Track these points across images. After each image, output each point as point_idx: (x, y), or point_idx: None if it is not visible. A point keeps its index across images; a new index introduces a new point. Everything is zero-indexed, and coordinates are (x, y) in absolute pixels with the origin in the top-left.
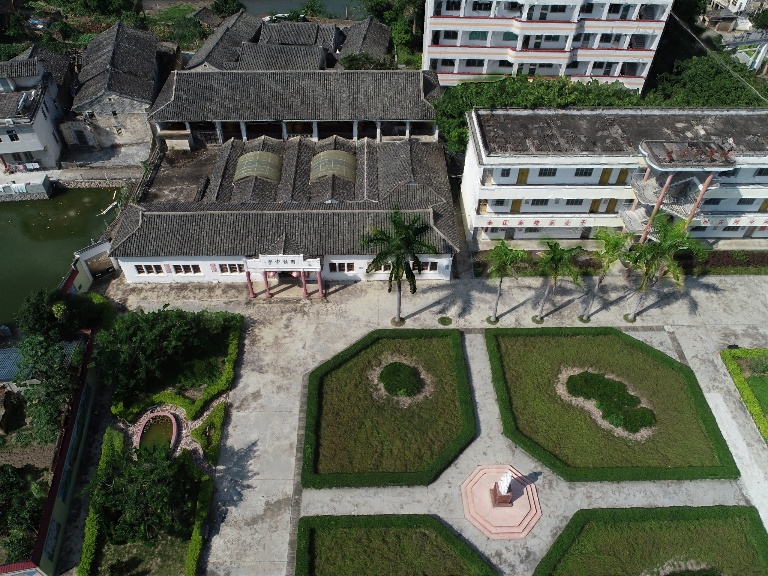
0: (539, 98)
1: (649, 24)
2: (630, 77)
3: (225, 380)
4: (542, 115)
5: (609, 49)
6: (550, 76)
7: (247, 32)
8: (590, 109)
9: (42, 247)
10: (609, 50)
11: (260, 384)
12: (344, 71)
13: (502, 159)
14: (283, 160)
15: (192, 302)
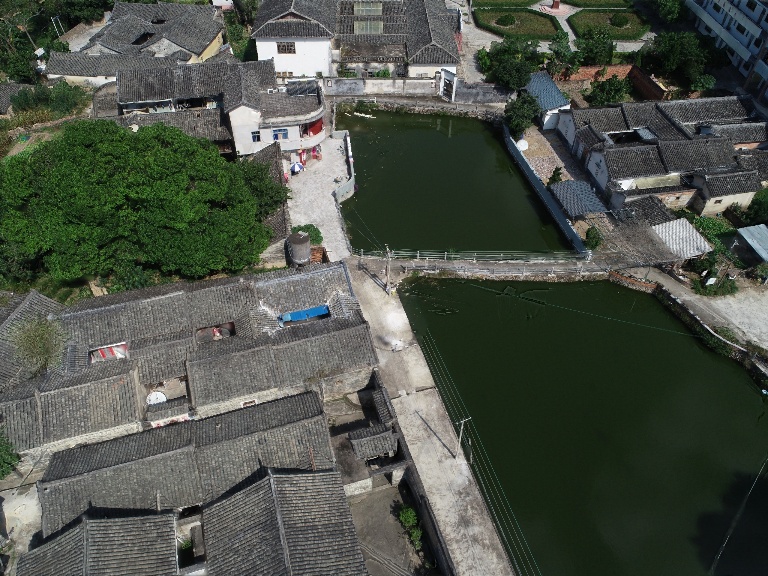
0: None
1: None
2: None
3: None
4: None
5: None
6: None
7: None
8: None
9: None
10: None
11: None
12: None
13: None
14: None
15: (466, 69)
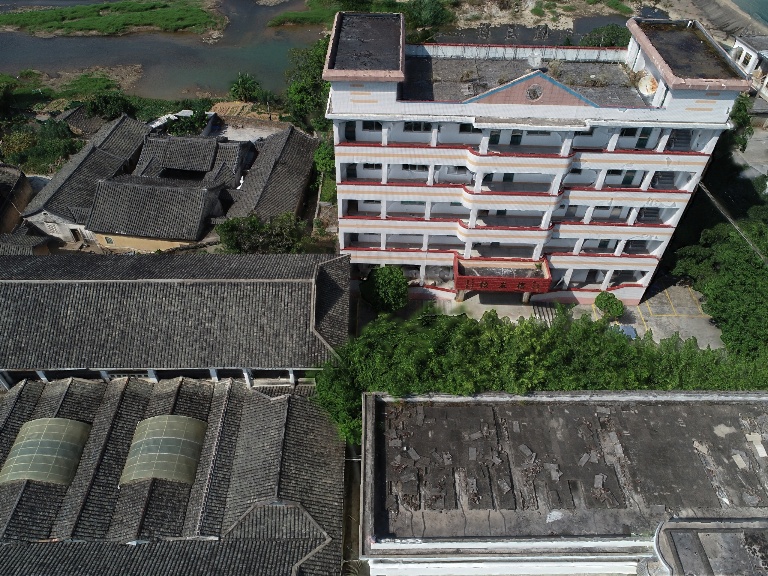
0: (483, 380)
1: (667, 195)
2: (637, 257)
3: None
4: (490, 402)
5: (606, 224)
6: (522, 248)
7: (124, 149)
8: (570, 395)
9: None
10: (606, 226)
11: None
12: (194, 281)
13: (403, 544)
14: (92, 427)
15: None
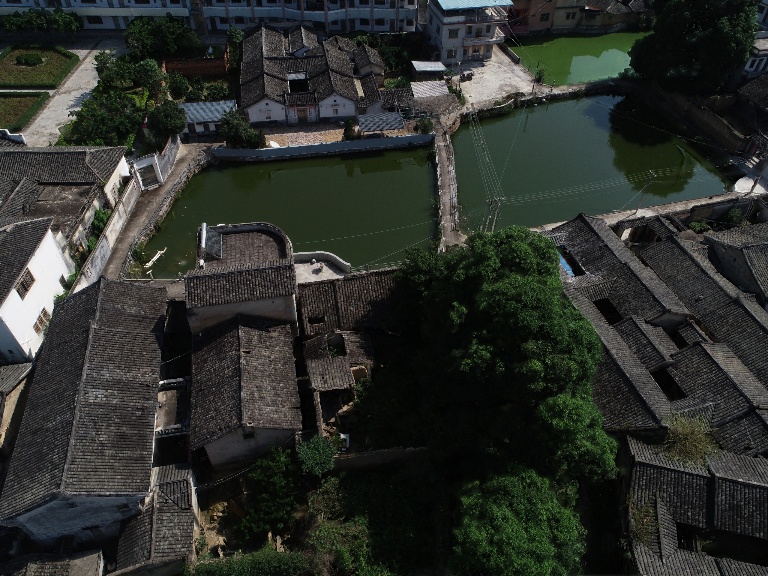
0: None
1: None
2: None
3: (72, 120)
4: None
5: None
6: None
7: None
8: None
9: (215, 221)
10: None
11: (54, 128)
12: None
13: None
14: None
15: None
